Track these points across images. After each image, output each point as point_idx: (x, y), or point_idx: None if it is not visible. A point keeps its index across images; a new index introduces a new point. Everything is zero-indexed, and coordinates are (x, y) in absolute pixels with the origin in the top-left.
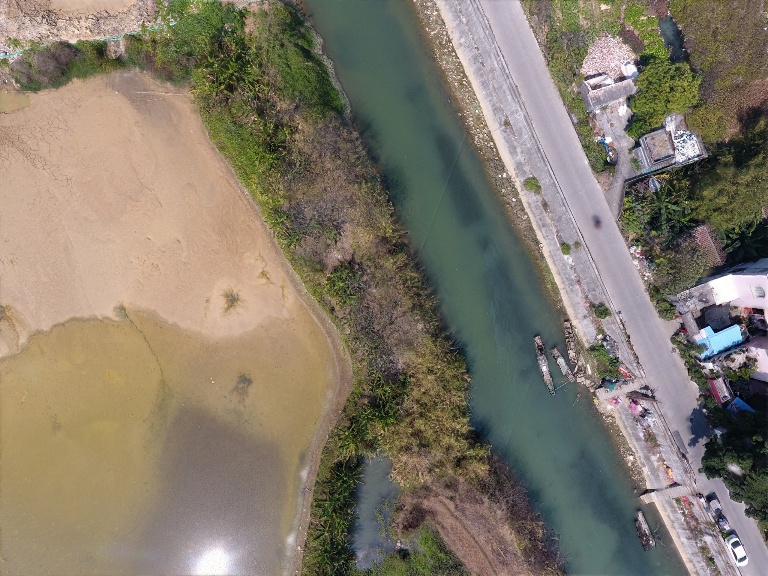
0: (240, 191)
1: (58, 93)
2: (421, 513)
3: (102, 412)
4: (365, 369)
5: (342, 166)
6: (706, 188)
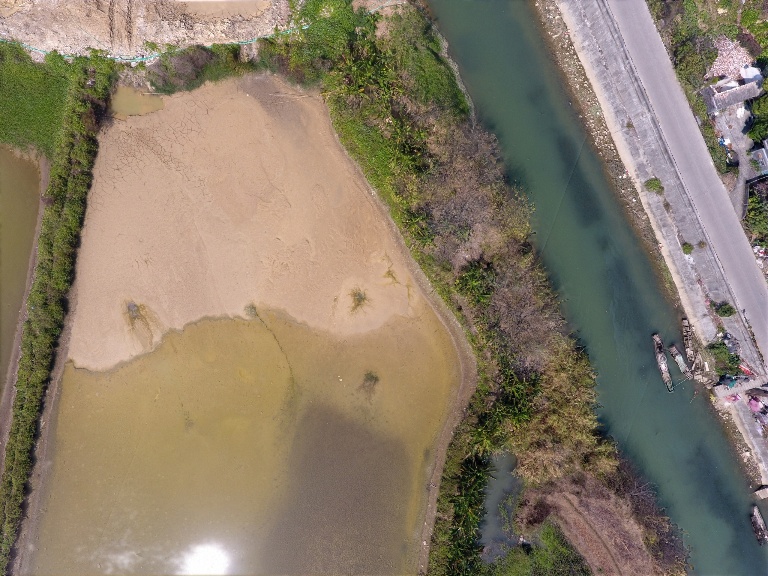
0: (367, 192)
1: (191, 96)
2: (546, 508)
3: (233, 409)
4: (491, 367)
5: (474, 167)
6: None
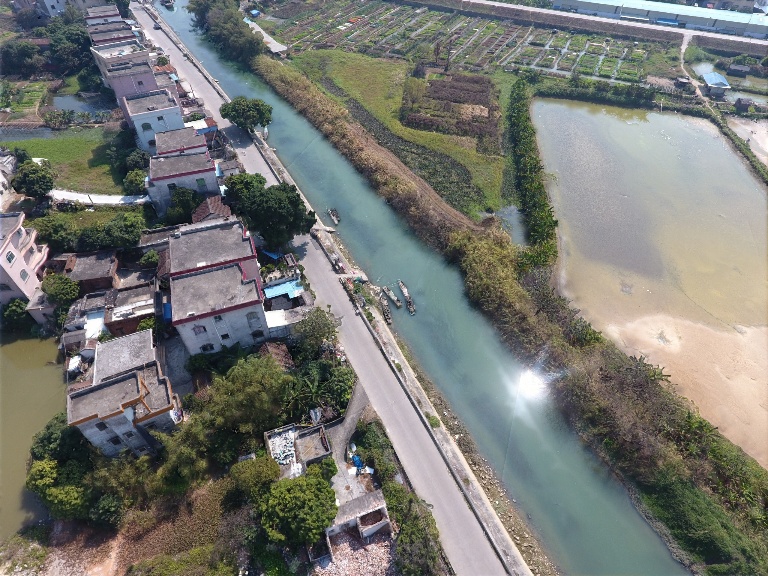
0: None
1: None
2: (485, 224)
3: (713, 276)
4: None
5: None
6: None
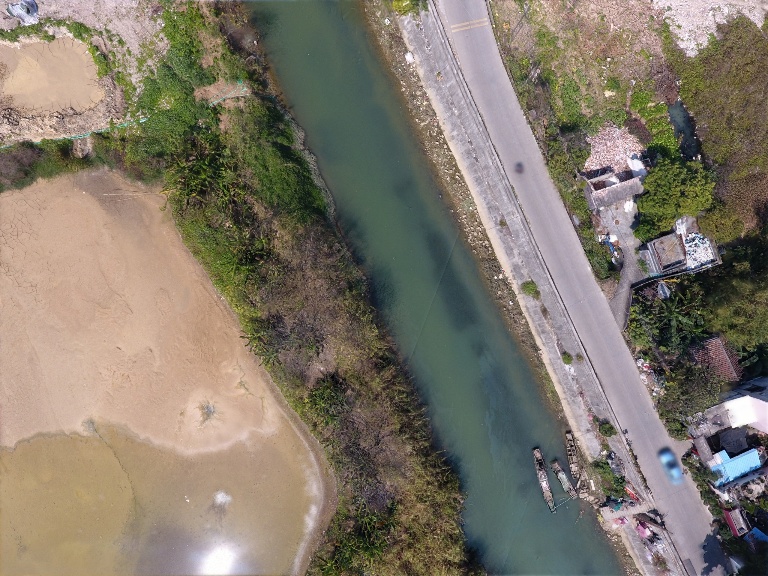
0: (216, 296)
1: (22, 194)
2: None
3: (69, 534)
4: (350, 488)
5: (324, 275)
6: (721, 304)
